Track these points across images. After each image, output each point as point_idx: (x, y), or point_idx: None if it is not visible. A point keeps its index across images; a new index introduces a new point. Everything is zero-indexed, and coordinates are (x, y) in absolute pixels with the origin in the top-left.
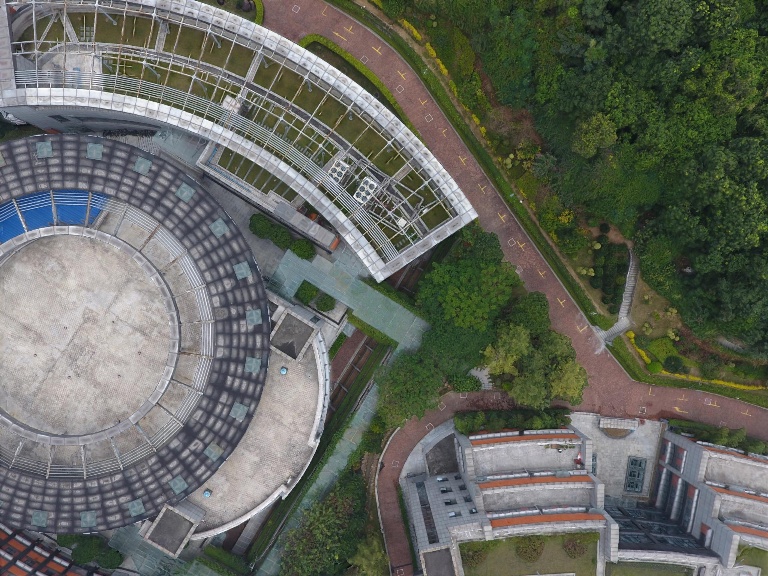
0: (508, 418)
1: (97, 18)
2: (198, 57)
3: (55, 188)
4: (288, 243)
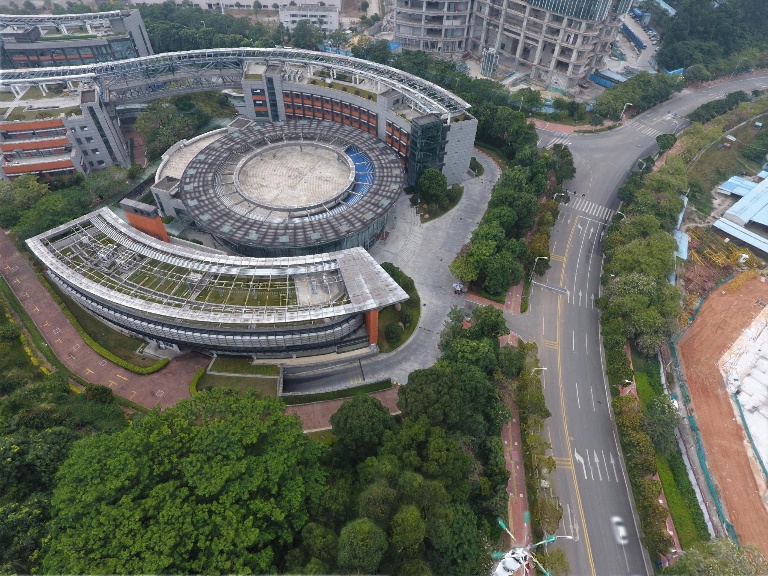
0: (50, 184)
1: (303, 324)
2: None
3: (308, 222)
4: (176, 237)
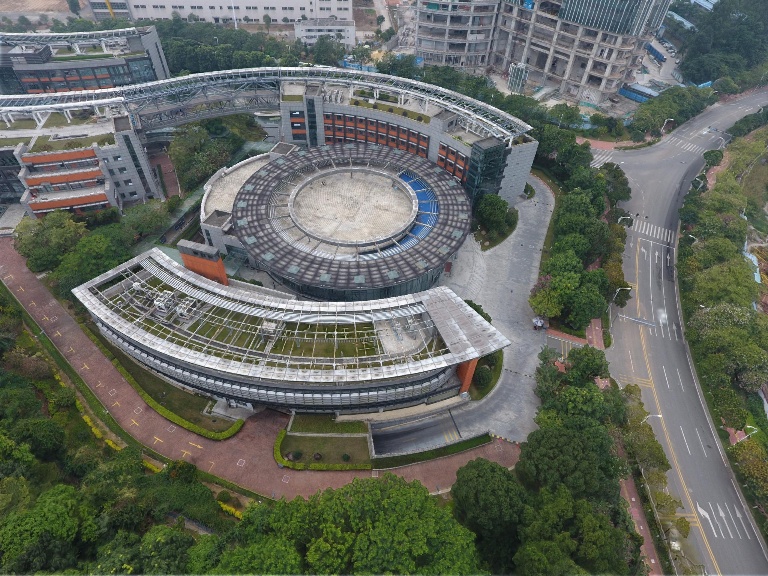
0: (81, 220)
1: None
2: (308, 366)
3: (381, 259)
4: (232, 278)
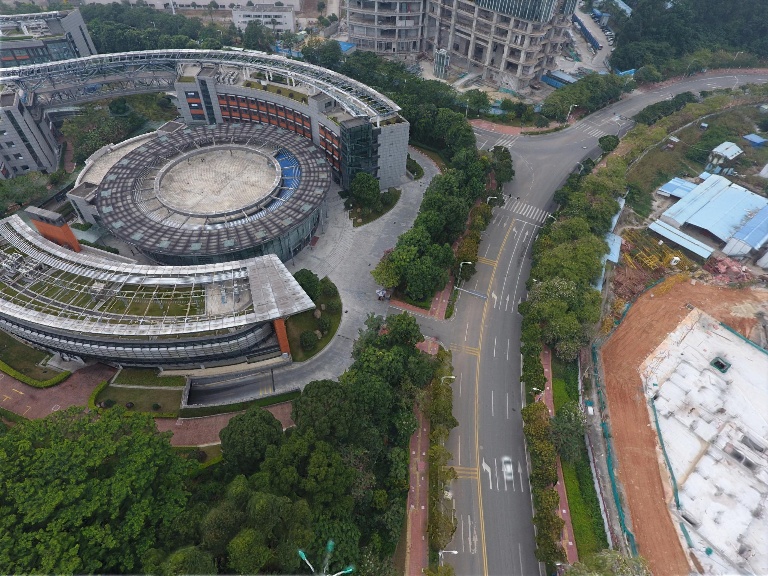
0: None
1: (207, 334)
2: None
3: (224, 229)
4: None
